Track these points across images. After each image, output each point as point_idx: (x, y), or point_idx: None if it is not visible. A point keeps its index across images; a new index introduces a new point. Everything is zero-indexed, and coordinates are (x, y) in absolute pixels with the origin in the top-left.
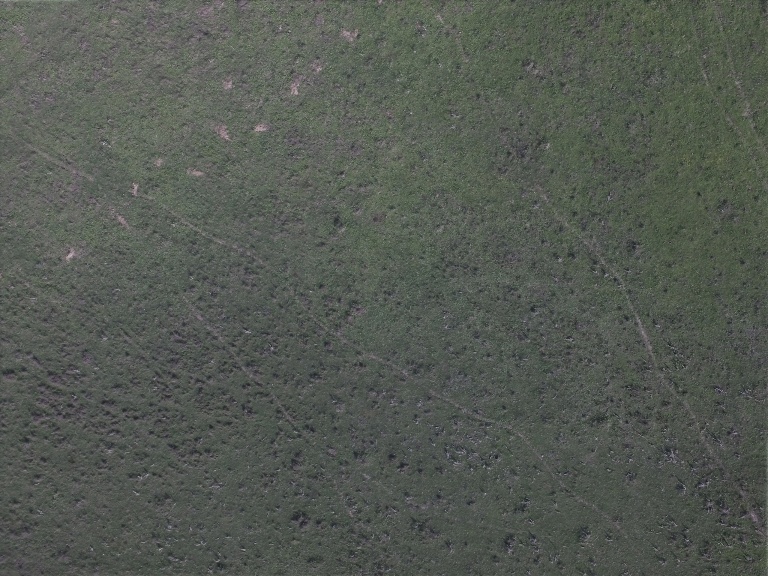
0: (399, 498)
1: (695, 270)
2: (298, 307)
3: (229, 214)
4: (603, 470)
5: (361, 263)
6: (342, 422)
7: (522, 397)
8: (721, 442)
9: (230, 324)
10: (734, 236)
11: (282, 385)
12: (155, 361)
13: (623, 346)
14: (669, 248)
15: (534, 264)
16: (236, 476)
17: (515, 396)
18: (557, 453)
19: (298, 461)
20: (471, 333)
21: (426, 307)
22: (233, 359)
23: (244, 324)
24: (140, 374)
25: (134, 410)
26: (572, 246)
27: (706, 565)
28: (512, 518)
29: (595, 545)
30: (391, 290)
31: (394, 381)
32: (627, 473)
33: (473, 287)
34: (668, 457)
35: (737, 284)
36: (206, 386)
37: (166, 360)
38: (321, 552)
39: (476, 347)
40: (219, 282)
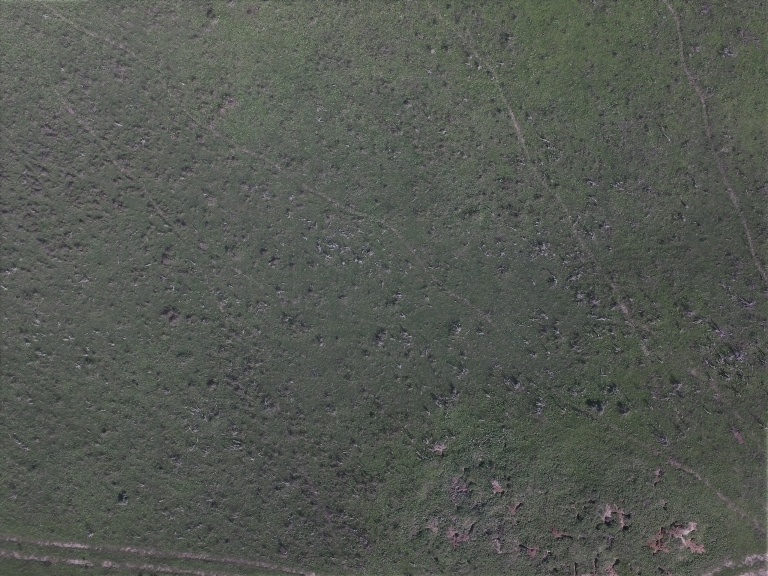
0: (270, 293)
1: (568, 62)
2: (170, 100)
3: (101, 6)
4: (475, 264)
5: (234, 56)
6: (214, 216)
7: (395, 190)
8: (593, 235)
9: (101, 117)
10: (606, 28)
11: (153, 179)
12: (25, 154)
13: (496, 139)
14: (542, 40)
15: (407, 56)
16: (106, 271)
17: (387, 189)
18: (429, 247)
19: (168, 255)
20: (344, 126)
21: (299, 100)
22: (104, 152)
23: (115, 117)
24: (10, 168)
25: (3, 204)
26: (446, 39)
27: (576, 357)
28: (383, 312)
29: (466, 339)
30: (264, 83)
31: (267, 175)
32: (499, 267)
33: (347, 80)
34: (540, 250)
35: (609, 76)
36: (76, 180)
37: (36, 154)
38: (191, 347)
39: (349, 141)
40: (91, 75)
